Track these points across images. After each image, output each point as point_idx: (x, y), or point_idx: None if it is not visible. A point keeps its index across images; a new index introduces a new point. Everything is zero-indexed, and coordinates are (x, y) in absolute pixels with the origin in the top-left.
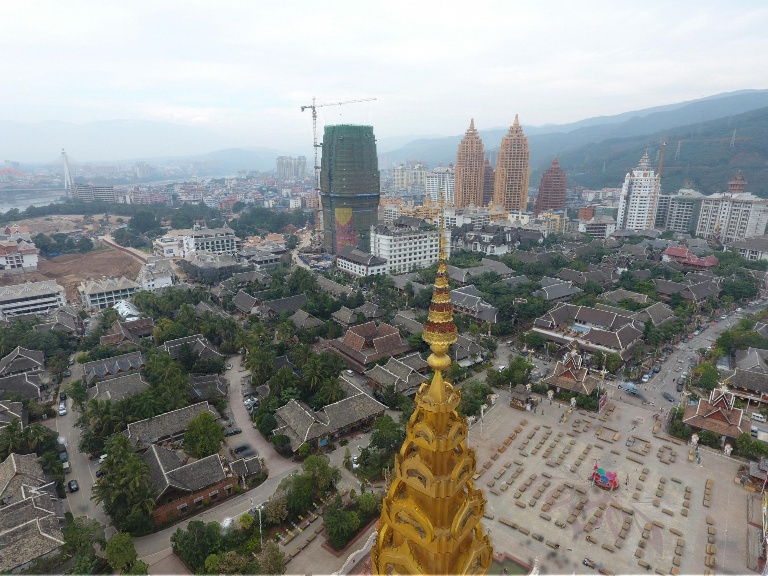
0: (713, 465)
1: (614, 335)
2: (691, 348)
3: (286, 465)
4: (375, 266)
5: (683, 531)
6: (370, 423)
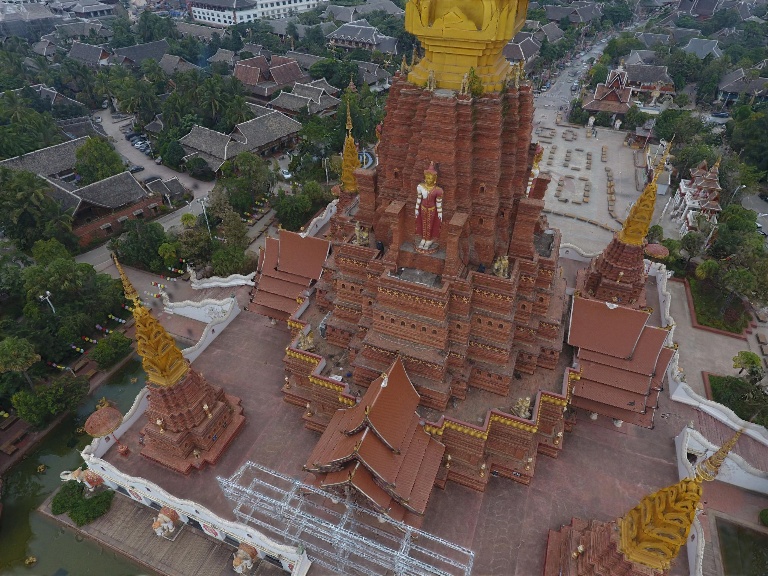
0: (606, 137)
1: (517, 46)
2: (579, 65)
3: (210, 187)
4: (243, 10)
5: (589, 178)
6: (290, 144)
